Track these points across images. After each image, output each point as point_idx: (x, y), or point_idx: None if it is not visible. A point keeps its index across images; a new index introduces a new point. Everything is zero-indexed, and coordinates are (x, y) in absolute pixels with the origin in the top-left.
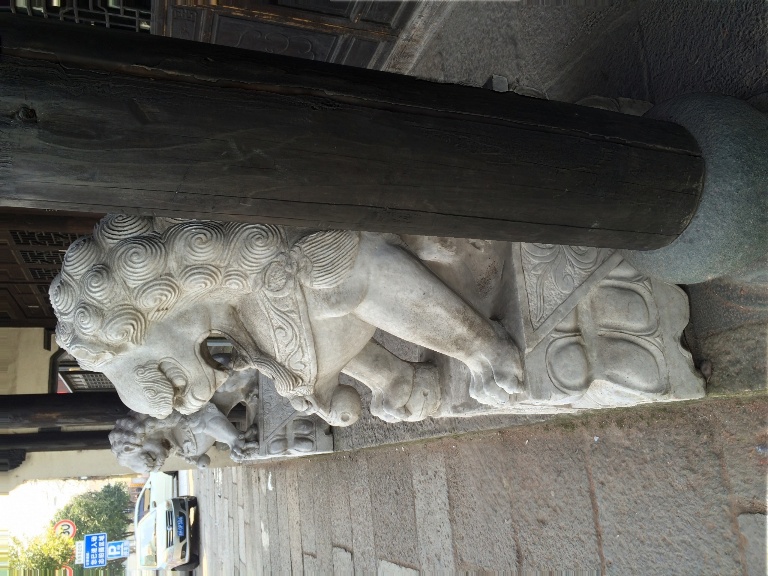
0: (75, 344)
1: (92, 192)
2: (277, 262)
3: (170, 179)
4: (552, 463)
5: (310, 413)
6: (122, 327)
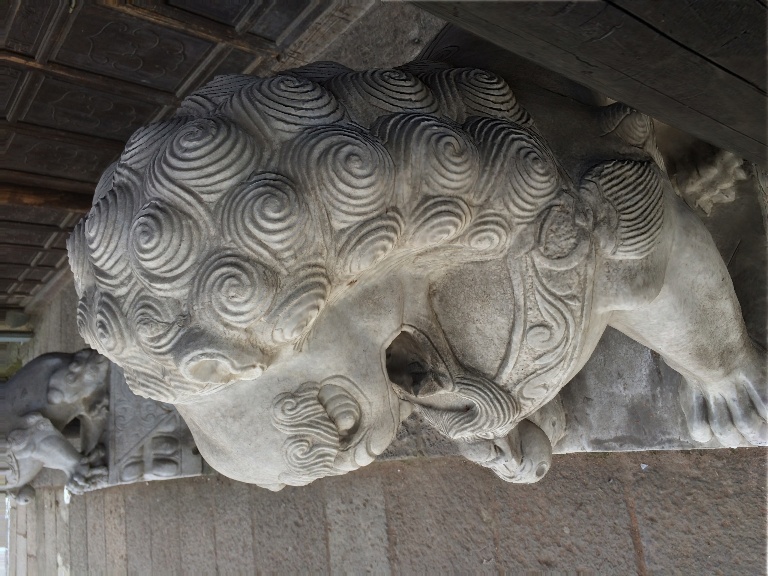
0: (202, 348)
1: None
2: (560, 206)
3: None
4: (568, 494)
5: None
6: (306, 313)
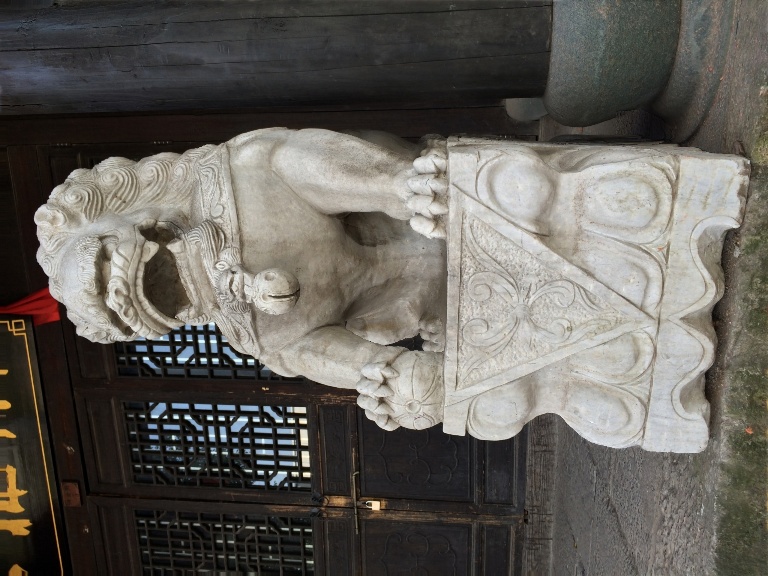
0: None
1: (73, 34)
2: None
3: (119, 18)
4: None
5: (235, 286)
6: (79, 190)
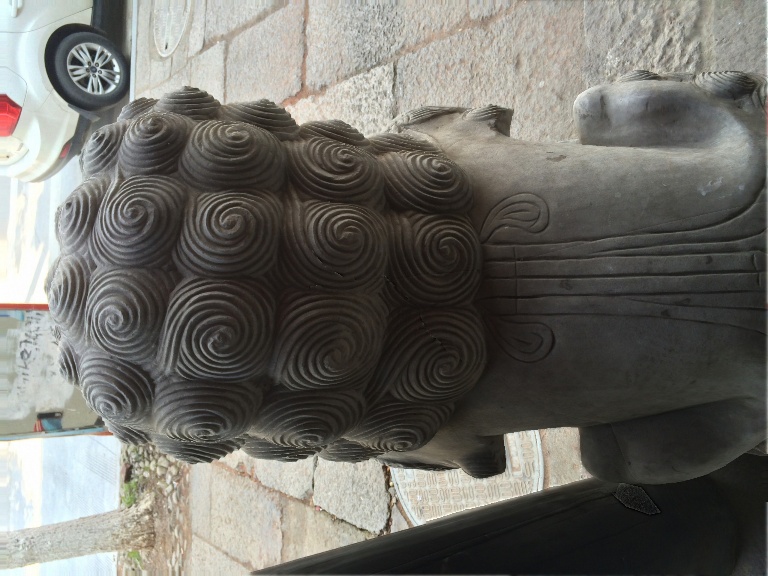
0: None
1: None
2: None
3: None
4: (569, 84)
5: None
6: None
